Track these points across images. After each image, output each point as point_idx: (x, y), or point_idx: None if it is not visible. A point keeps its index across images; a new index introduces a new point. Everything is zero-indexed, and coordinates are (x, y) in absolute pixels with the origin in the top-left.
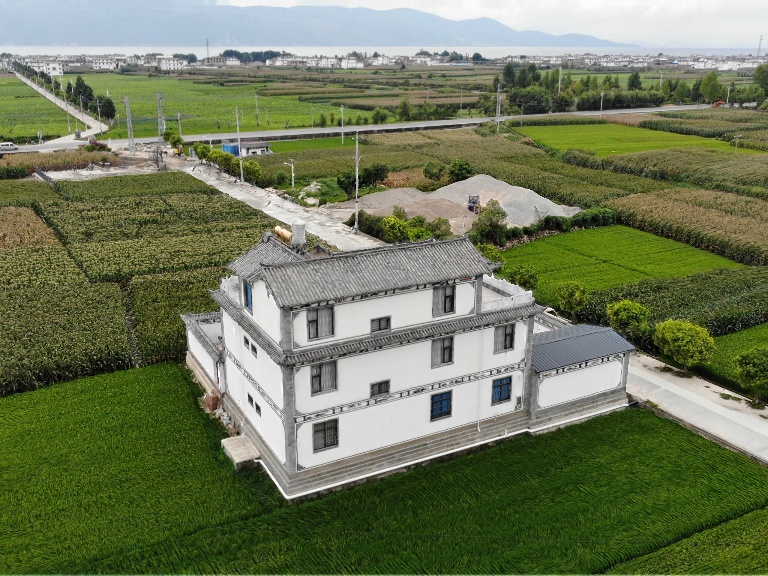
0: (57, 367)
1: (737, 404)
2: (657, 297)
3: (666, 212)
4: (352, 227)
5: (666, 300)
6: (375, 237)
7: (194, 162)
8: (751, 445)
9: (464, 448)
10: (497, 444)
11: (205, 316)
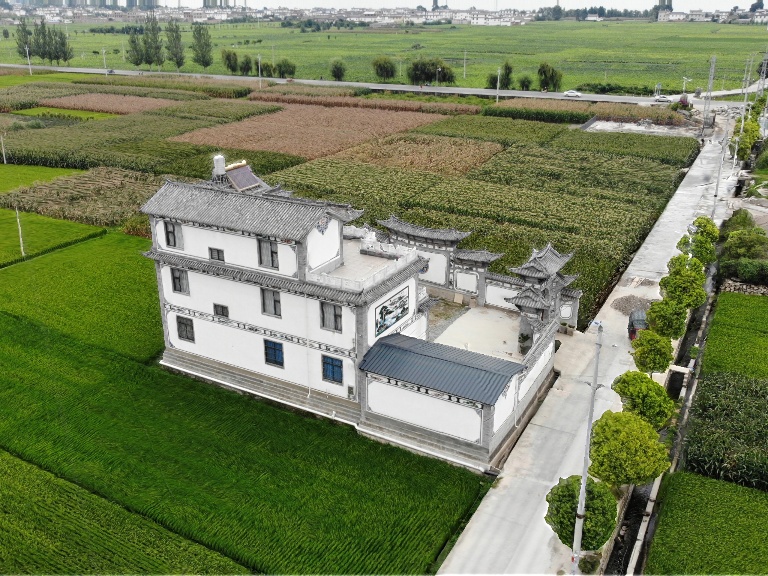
0: None
1: None
2: None
3: None
4: None
5: None
6: (717, 242)
7: None
8: (458, 571)
9: (290, 404)
10: (321, 420)
11: None
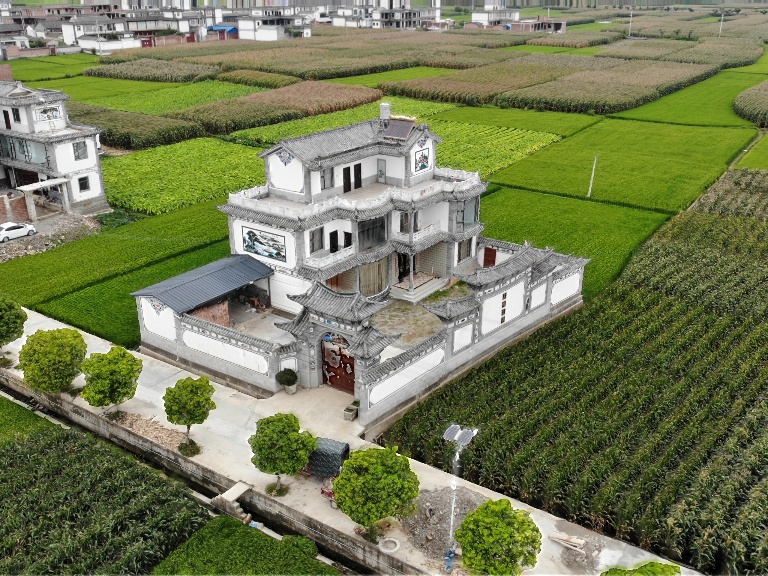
0: None
1: None
2: None
3: None
4: None
5: None
6: None
7: None
8: (47, 324)
9: None
10: None
11: None
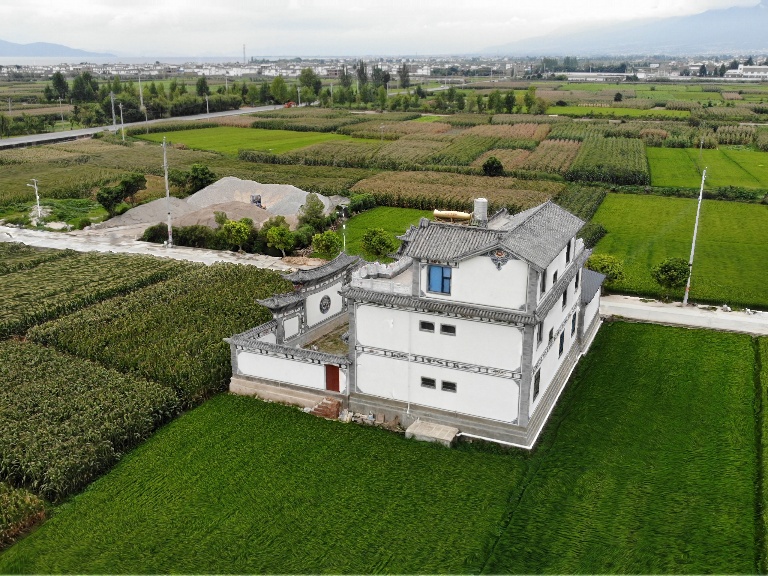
0: None
1: (656, 303)
2: None
3: (412, 190)
4: (166, 241)
5: None
6: (197, 247)
7: None
8: (701, 323)
9: (569, 376)
10: (576, 369)
11: (248, 334)
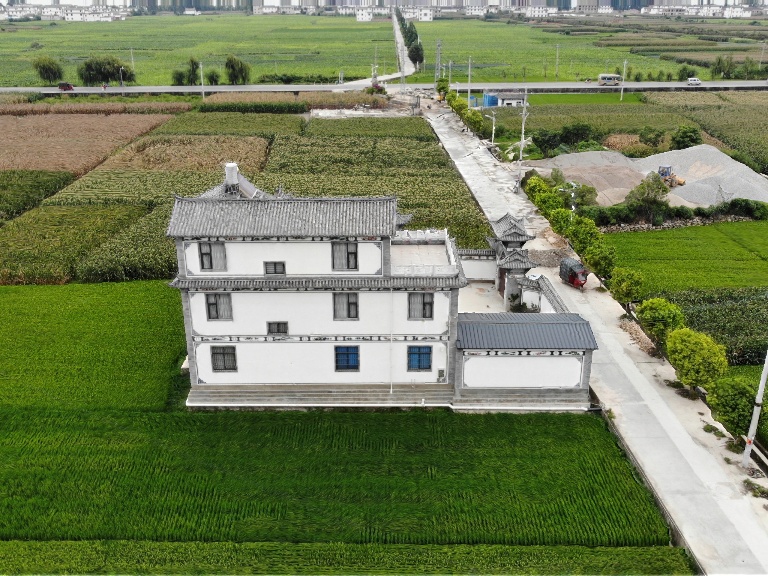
0: (143, 267)
1: (713, 440)
2: (760, 307)
3: None
4: (514, 186)
5: (766, 312)
6: None
7: (448, 109)
8: (668, 484)
9: (371, 405)
10: (410, 411)
11: None
